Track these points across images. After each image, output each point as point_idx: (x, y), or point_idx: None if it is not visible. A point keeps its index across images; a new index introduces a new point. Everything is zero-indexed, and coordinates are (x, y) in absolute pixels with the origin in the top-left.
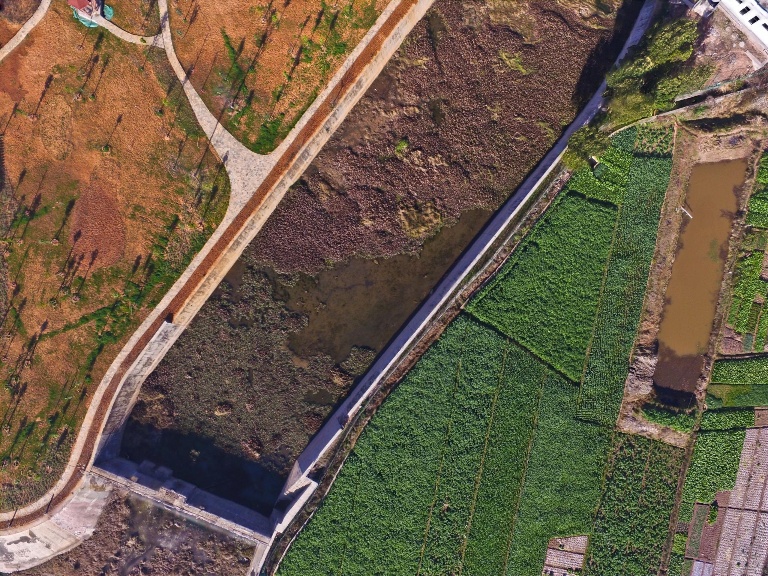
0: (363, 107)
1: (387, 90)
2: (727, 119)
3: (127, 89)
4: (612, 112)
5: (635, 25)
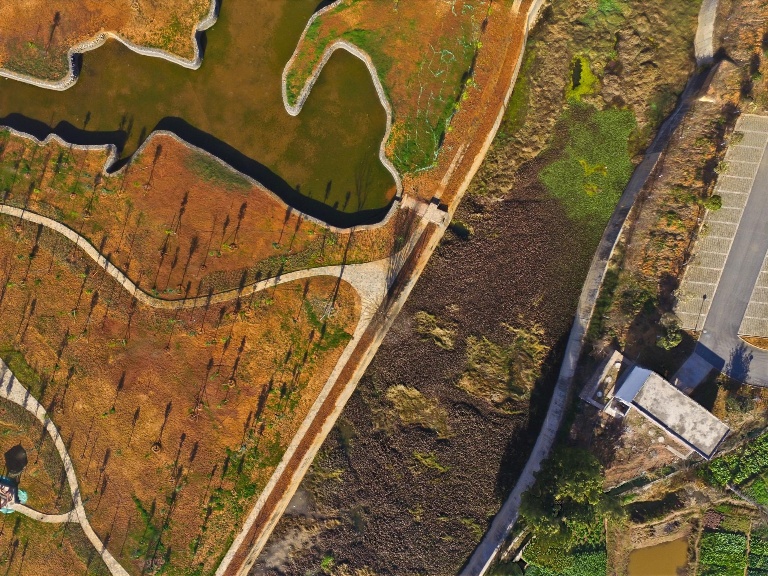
0: (284, 526)
1: (306, 505)
2: (659, 502)
3: (49, 567)
4: None
5: (551, 405)
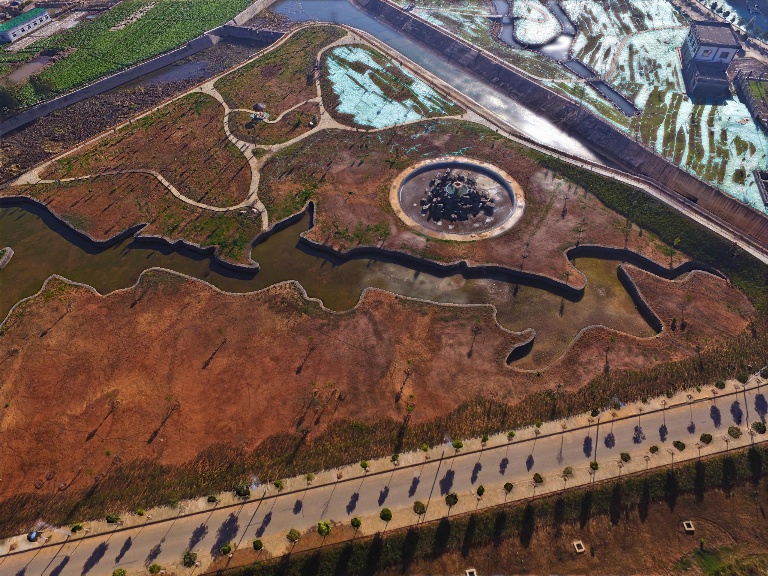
0: None
1: None
2: None
3: None
4: (19, 110)
5: None
